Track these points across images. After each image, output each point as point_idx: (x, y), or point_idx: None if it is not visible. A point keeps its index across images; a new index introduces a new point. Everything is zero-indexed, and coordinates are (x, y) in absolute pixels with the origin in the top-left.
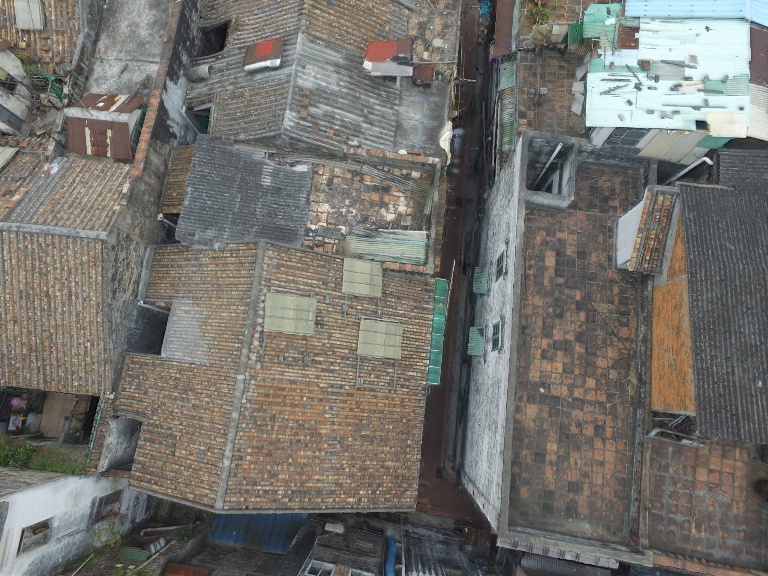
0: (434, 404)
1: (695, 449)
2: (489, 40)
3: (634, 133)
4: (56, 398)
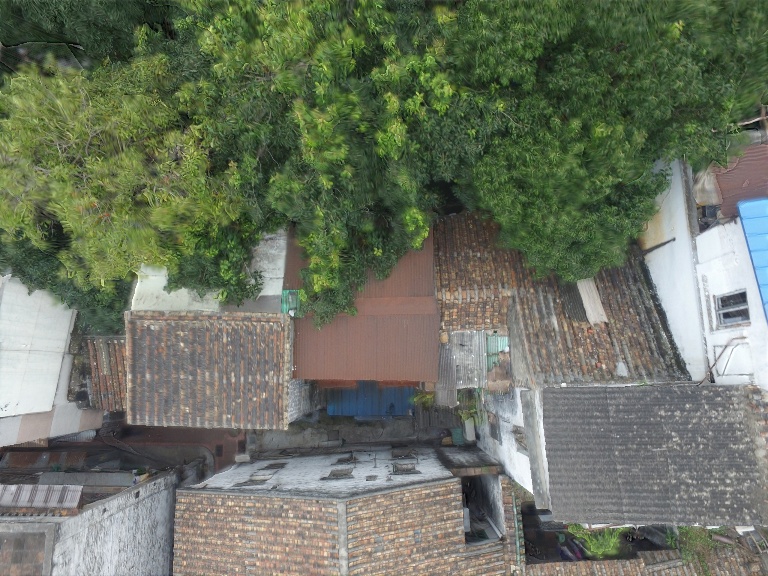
0: None
1: None
2: None
3: None
4: None
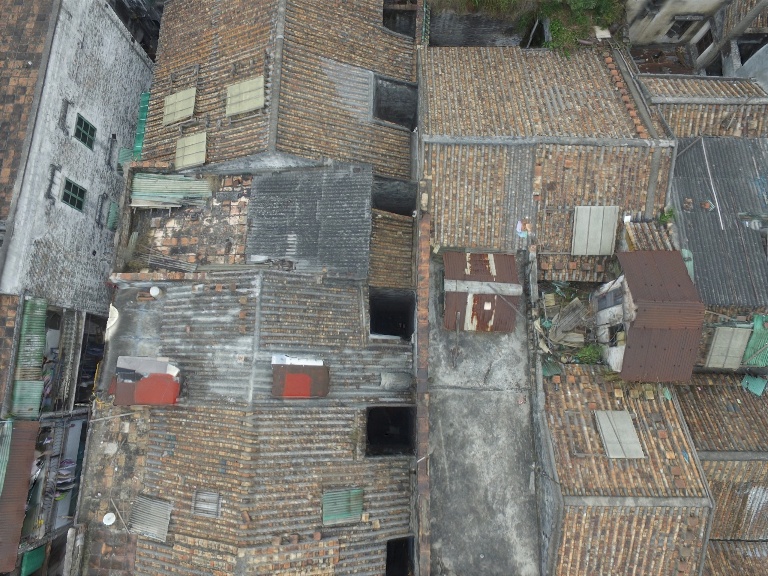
0: None
1: None
2: None
3: None
4: None
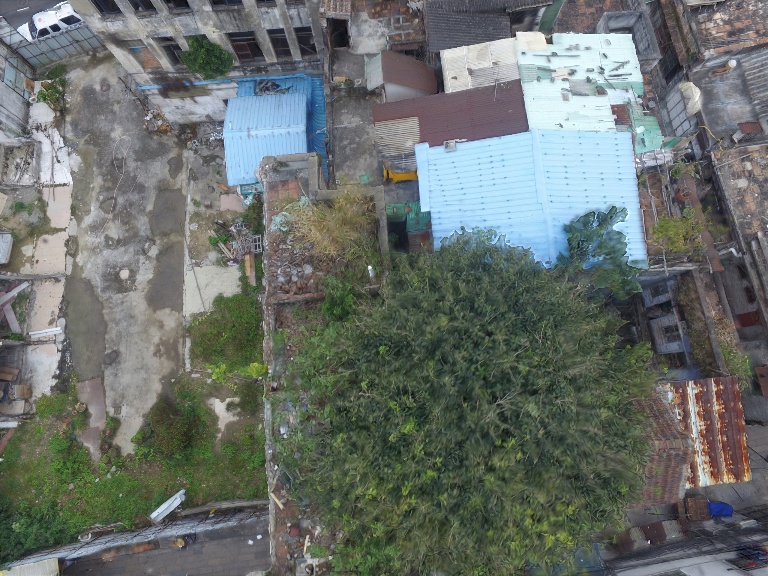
0: None
1: None
2: None
3: None
4: None
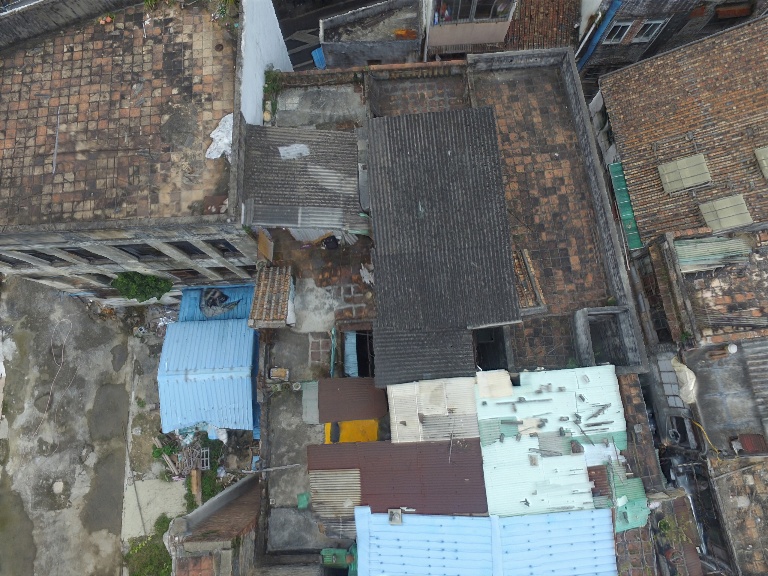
0: None
1: None
2: None
3: None
4: None
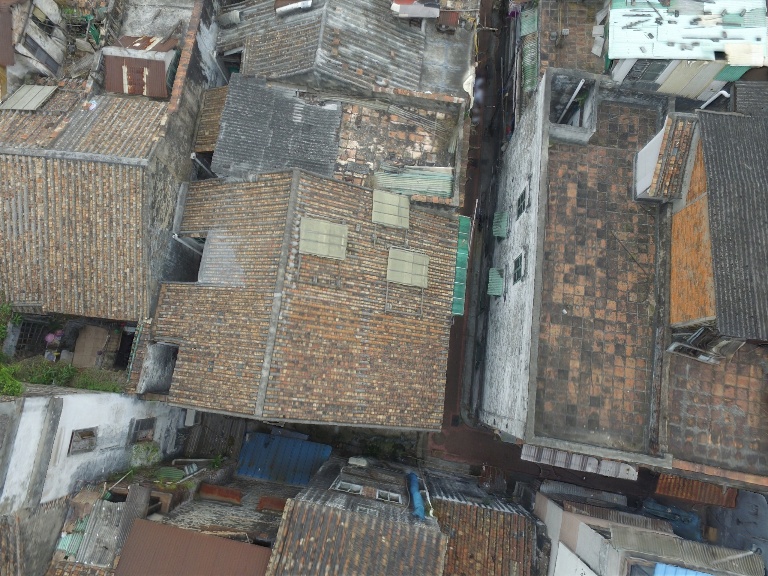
0: (450, 355)
1: (711, 366)
2: (506, 2)
3: (655, 66)
4: (87, 337)
